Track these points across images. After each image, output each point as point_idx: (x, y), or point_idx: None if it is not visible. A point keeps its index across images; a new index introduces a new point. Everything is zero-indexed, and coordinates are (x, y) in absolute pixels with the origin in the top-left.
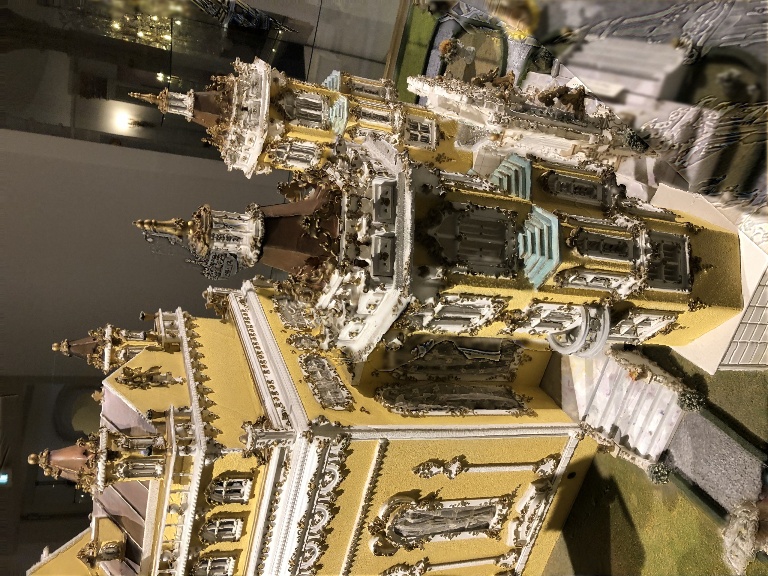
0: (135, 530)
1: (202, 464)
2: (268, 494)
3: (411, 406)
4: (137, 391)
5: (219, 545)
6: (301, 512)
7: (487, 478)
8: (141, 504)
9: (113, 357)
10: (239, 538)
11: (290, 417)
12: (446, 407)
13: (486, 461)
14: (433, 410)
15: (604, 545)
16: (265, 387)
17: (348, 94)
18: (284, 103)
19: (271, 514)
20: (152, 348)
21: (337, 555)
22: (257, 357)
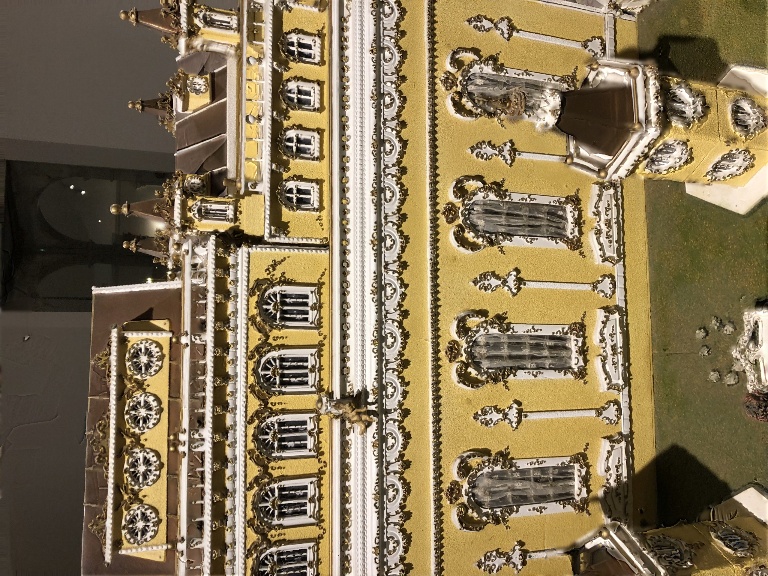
0: (218, 157)
1: (272, 2)
2: (336, 22)
3: None
4: None
5: (301, 119)
6: (370, 38)
7: (541, 50)
8: (221, 123)
9: None
10: (319, 108)
11: None
12: None
13: (533, 30)
14: None
15: None
16: None
17: None
18: None
19: (343, 54)
20: None
21: (418, 114)
22: None
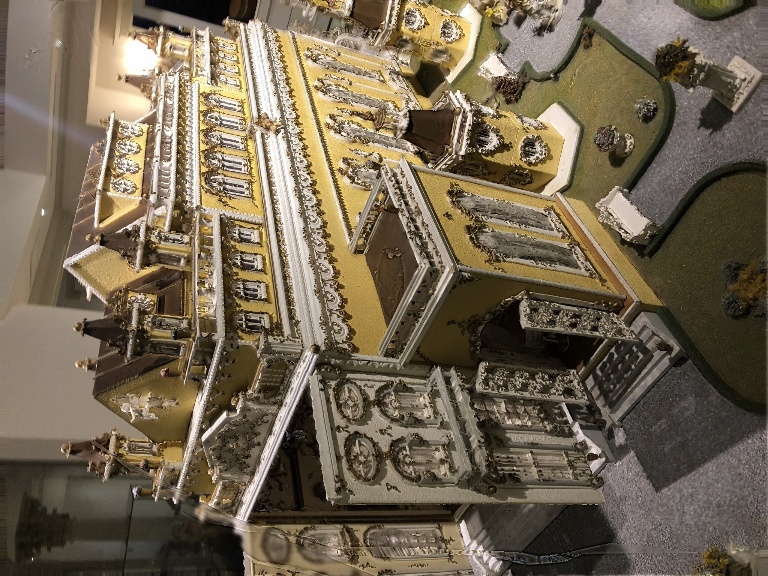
0: None
1: None
2: None
3: None
4: None
5: None
6: None
7: None
8: None
9: None
10: None
11: None
12: None
13: None
14: None
15: None
16: None
17: None
18: None
19: None
20: None
21: None
22: None
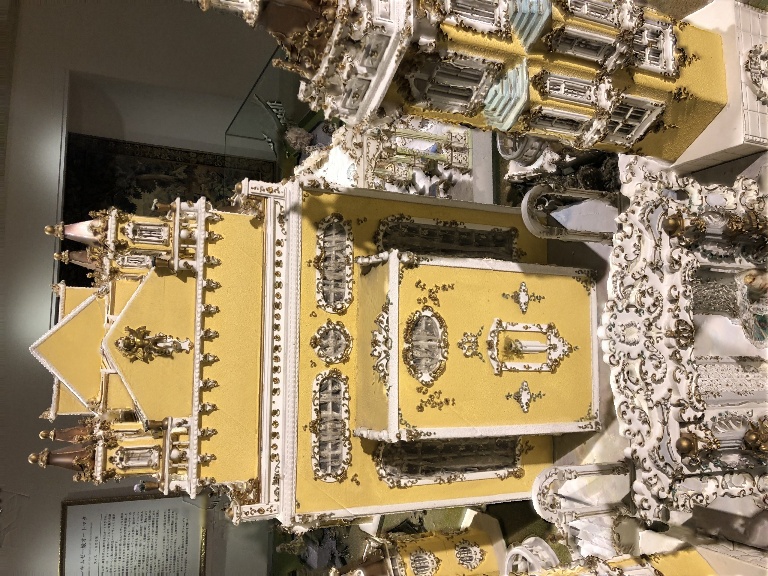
0: None
1: None
2: None
3: (404, 472)
4: (138, 366)
5: None
6: None
7: None
8: None
9: (118, 253)
10: None
11: (280, 486)
12: (439, 471)
13: None
14: (424, 474)
15: (520, 522)
16: (267, 432)
17: (541, 54)
18: (415, 74)
19: None
20: (162, 270)
21: None
22: (272, 360)
